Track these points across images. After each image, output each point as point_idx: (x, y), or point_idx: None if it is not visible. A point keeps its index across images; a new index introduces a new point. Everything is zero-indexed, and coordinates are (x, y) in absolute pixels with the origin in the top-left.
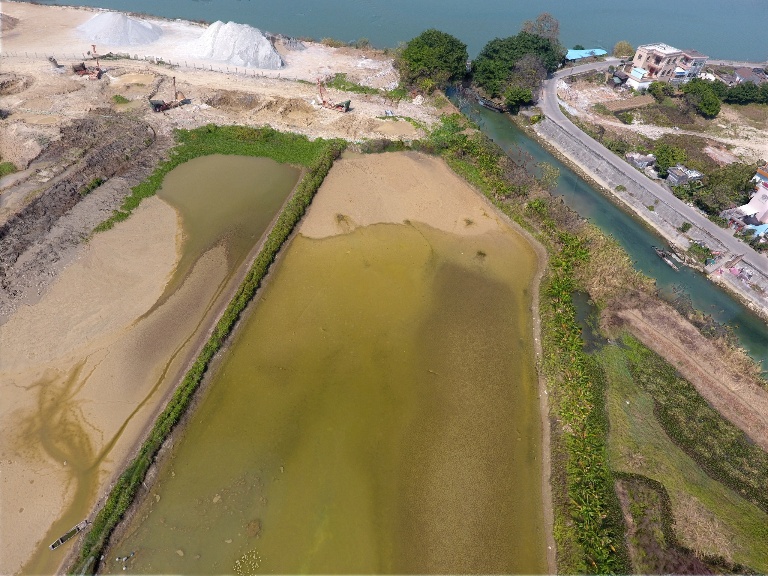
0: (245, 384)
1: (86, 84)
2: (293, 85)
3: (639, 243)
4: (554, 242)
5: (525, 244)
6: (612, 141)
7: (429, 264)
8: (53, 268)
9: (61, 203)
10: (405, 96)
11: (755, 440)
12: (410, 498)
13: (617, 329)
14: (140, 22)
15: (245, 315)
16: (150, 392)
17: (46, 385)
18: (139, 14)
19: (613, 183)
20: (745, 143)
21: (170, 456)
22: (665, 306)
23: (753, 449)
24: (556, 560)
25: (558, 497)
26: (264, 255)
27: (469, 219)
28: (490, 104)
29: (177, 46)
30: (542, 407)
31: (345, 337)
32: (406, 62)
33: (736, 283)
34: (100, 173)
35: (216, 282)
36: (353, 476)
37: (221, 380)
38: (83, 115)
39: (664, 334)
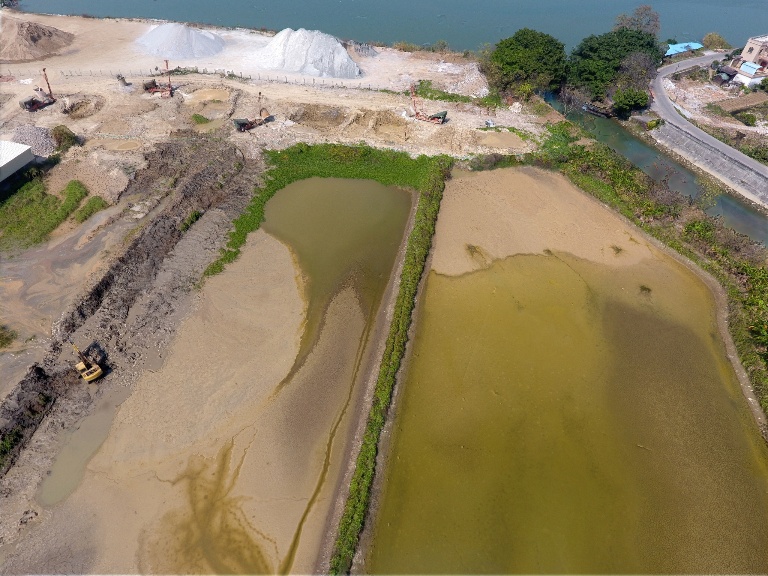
0: (426, 470)
1: (160, 103)
2: (376, 95)
3: None
4: (728, 272)
5: (690, 275)
6: (755, 148)
7: (590, 304)
8: (169, 323)
9: (162, 243)
10: (500, 103)
11: None
12: None
13: None
14: (200, 32)
15: (401, 377)
16: (317, 484)
17: (194, 478)
18: (196, 24)
19: (767, 197)
20: None
21: (364, 575)
22: None
23: None
24: None
25: None
26: (405, 300)
27: (616, 246)
28: (594, 109)
29: (244, 57)
30: None
31: (524, 402)
32: (498, 66)
33: None
34: (197, 205)
35: (356, 335)
36: None
37: (396, 465)
38: (165, 138)
39: None
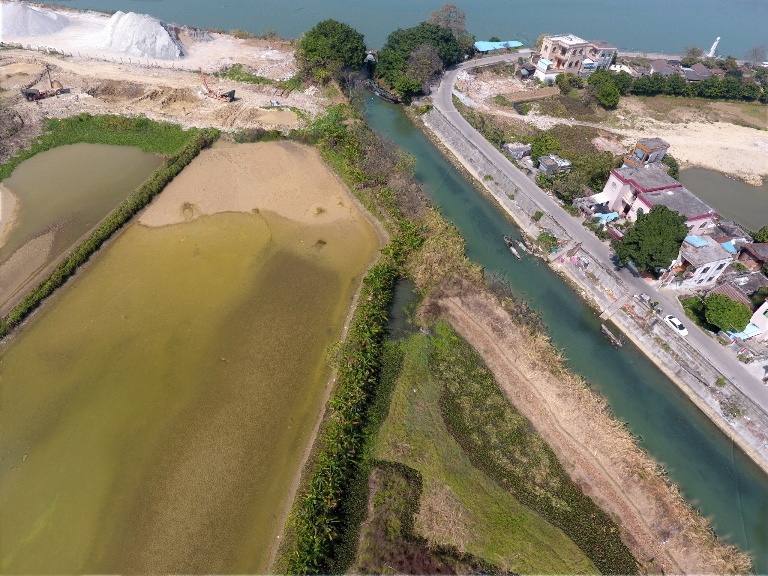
0: (20, 371)
1: None
2: (186, 75)
3: (491, 232)
4: (398, 230)
5: (371, 233)
6: None
7: (262, 252)
8: None
9: None
10: (299, 86)
11: (537, 428)
12: (150, 486)
13: (431, 317)
14: (47, 13)
15: (47, 302)
16: None
17: None
18: (51, 5)
19: (482, 172)
20: (638, 134)
21: None
22: (485, 294)
23: (531, 438)
24: (277, 549)
25: (301, 485)
26: (86, 242)
27: (322, 208)
28: (385, 95)
29: (78, 37)
30: (325, 395)
31: (145, 325)
32: (302, 52)
33: (574, 272)
34: None
35: (30, 269)
36: (98, 464)
37: None
38: None
39: (478, 322)
